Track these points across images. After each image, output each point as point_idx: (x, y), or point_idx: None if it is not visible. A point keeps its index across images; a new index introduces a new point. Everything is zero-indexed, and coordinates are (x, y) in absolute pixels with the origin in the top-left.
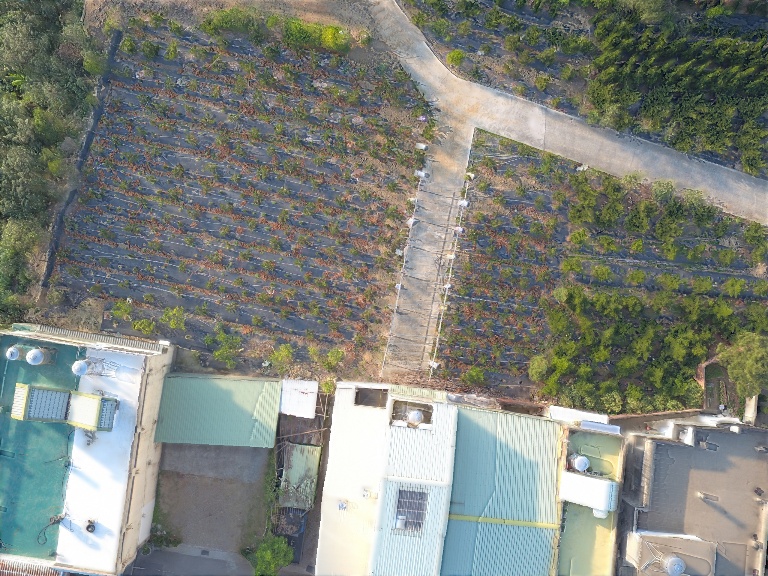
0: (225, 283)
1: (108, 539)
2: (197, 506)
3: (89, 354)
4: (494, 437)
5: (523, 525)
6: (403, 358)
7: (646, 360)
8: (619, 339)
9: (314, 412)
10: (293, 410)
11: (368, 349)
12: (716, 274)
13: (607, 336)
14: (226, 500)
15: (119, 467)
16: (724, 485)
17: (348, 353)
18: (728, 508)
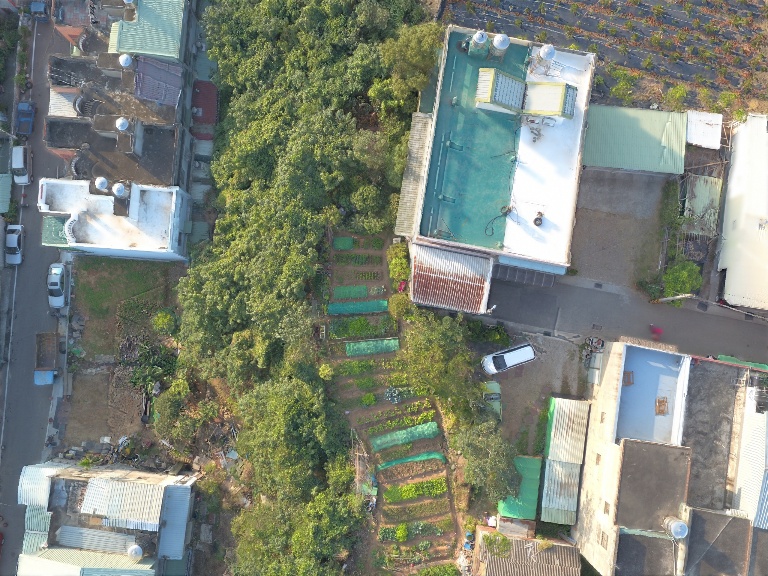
0: (614, 27)
1: (554, 234)
2: (590, 240)
3: (534, 54)
4: None
5: None
6: None
7: None
8: None
9: (719, 143)
10: (699, 140)
11: (753, 97)
12: None
13: None
14: (619, 235)
15: (564, 164)
16: None
17: (734, 100)
18: None
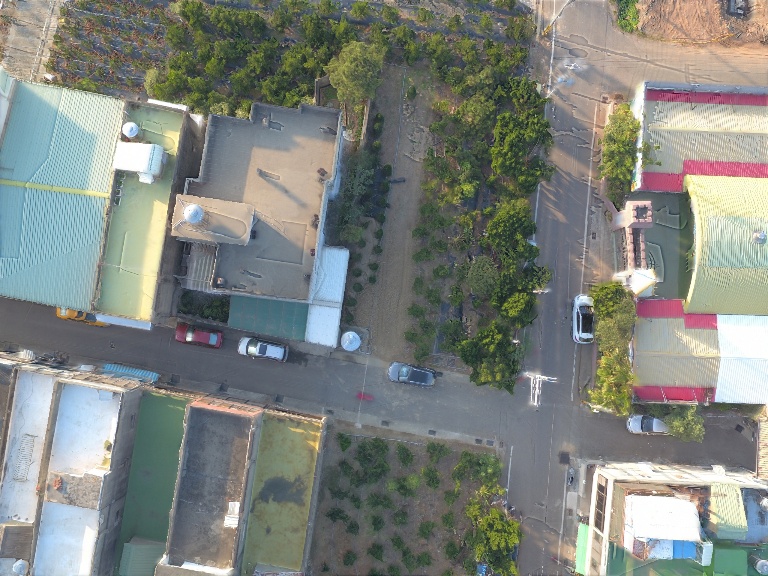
0: None
1: None
2: None
3: None
4: (55, 110)
5: (71, 192)
6: (18, 69)
7: (258, 73)
8: (233, 52)
9: None
10: None
11: None
12: (346, 0)
13: (216, 45)
14: None
15: None
16: (287, 164)
17: None
18: (289, 187)
